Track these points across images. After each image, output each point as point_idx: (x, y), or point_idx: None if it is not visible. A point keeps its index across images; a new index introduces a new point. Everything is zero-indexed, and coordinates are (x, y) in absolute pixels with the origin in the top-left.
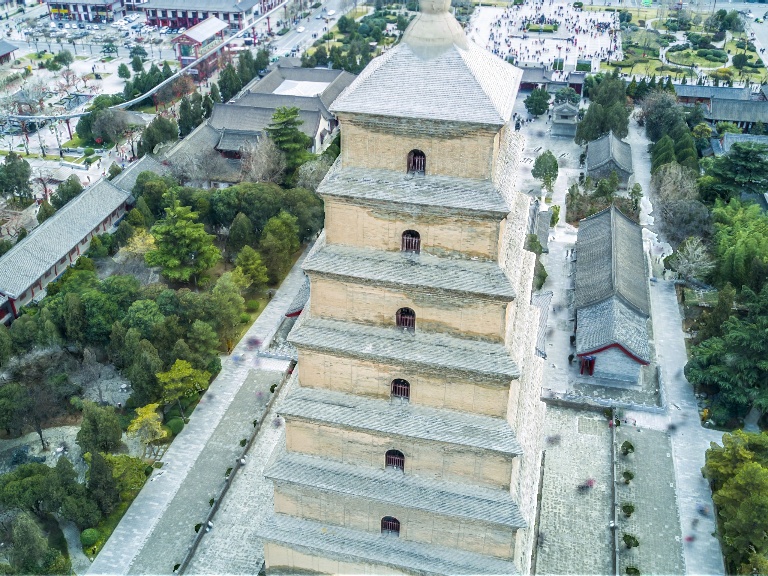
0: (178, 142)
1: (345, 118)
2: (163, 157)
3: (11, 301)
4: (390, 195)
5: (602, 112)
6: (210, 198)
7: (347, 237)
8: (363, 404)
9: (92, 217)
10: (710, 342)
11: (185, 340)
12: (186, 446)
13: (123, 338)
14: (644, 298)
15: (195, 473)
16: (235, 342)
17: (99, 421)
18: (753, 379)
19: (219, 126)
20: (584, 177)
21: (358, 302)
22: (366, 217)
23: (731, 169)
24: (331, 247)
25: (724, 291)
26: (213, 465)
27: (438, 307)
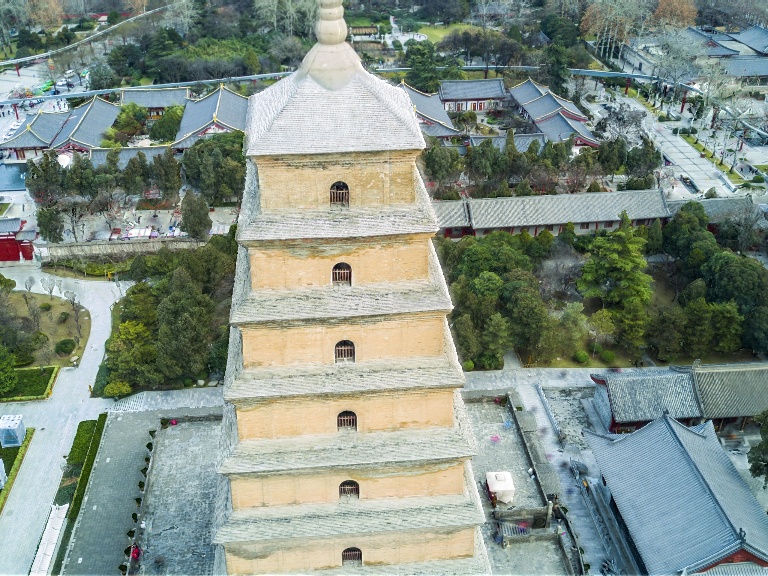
0: None
1: None
2: None
3: None
4: None
5: None
6: (710, 254)
7: None
8: None
9: (609, 212)
10: None
11: None
12: None
13: None
14: None
15: None
16: (544, 365)
17: None
18: None
19: None
20: None
21: None
22: None
23: None
24: None
25: None
26: None
27: None
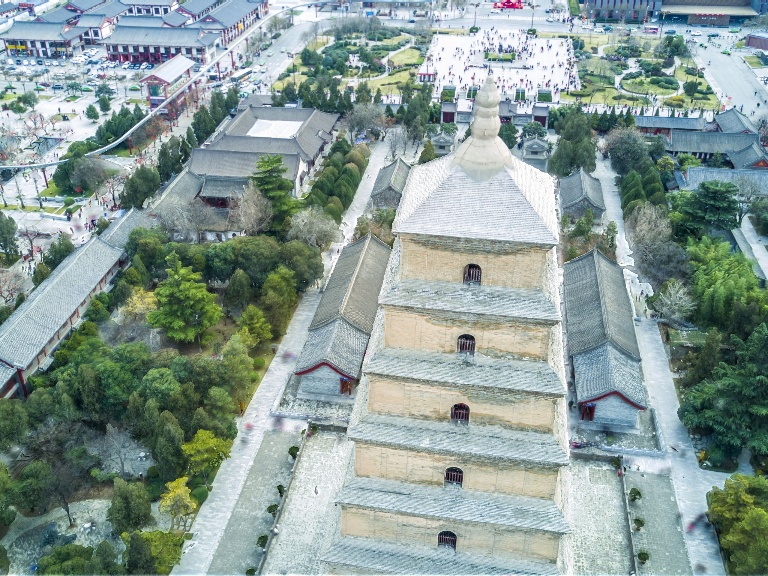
0: (162, 191)
1: (406, 237)
2: (149, 208)
3: (19, 371)
4: (449, 305)
5: (571, 148)
6: (205, 254)
7: (405, 341)
8: (418, 491)
9: (89, 278)
10: (702, 386)
11: (201, 406)
12: (213, 515)
13: (141, 408)
14: (634, 342)
15: (226, 543)
16: (246, 402)
17: (131, 499)
18: (746, 423)
19: (198, 171)
20: (559, 214)
21: (415, 399)
22: (424, 324)
23: (701, 208)
24: (390, 350)
25: (711, 336)
26: (242, 533)
27: (491, 403)
